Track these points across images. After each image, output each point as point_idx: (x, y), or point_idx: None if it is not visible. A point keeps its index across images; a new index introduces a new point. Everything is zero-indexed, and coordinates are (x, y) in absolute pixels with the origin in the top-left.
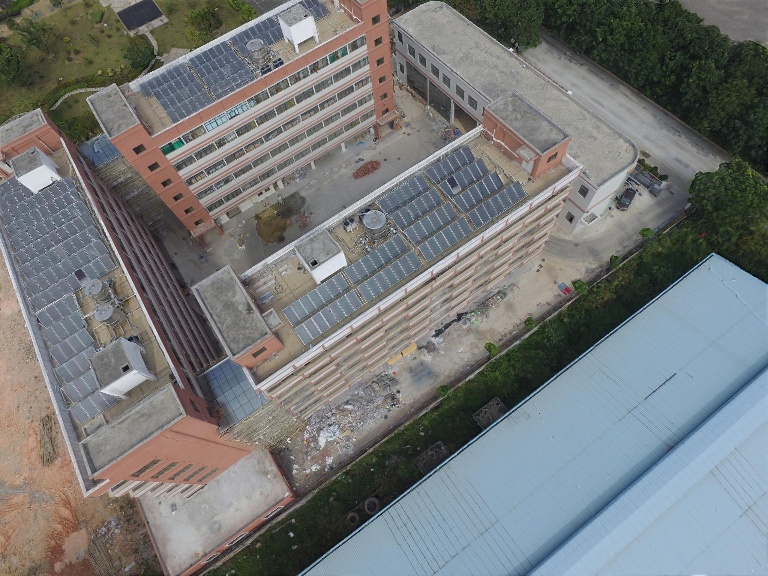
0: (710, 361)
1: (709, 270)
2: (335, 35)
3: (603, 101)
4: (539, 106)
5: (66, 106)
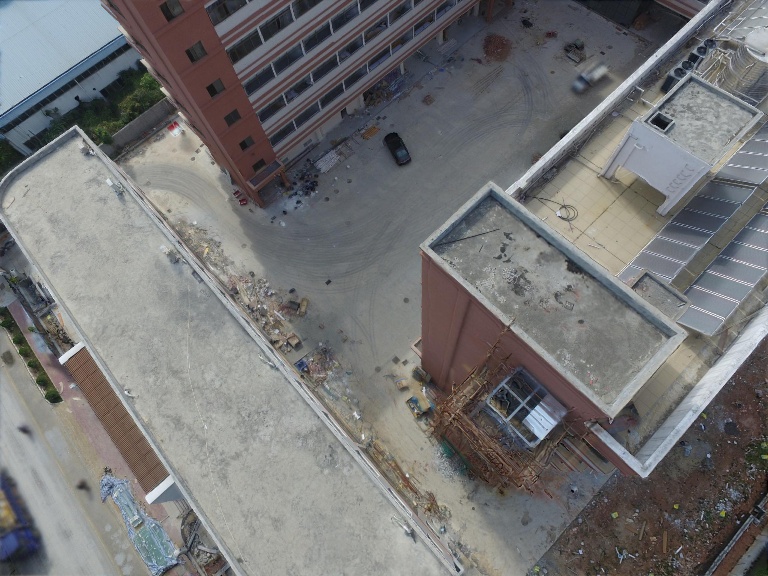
0: (44, 5)
1: (1, 103)
2: (563, 202)
3: (28, 485)
4: (122, 281)
5: None
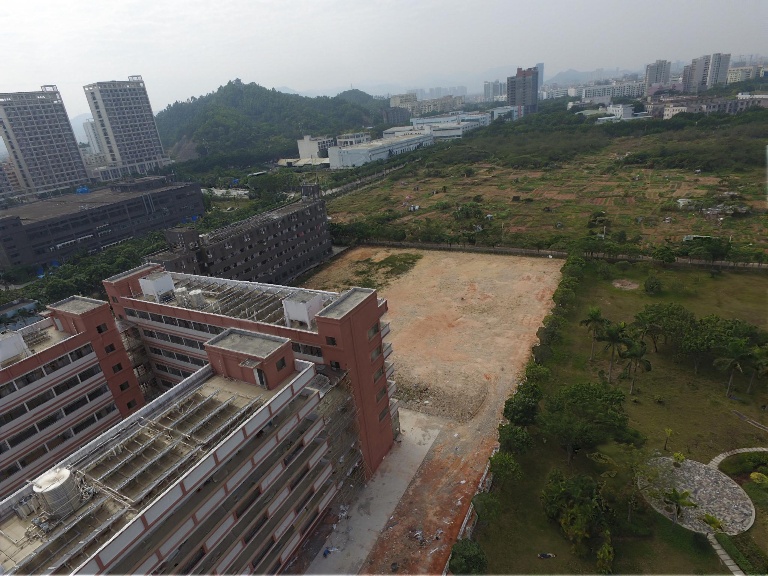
0: None
1: None
2: None
3: None
4: None
5: (703, 568)
